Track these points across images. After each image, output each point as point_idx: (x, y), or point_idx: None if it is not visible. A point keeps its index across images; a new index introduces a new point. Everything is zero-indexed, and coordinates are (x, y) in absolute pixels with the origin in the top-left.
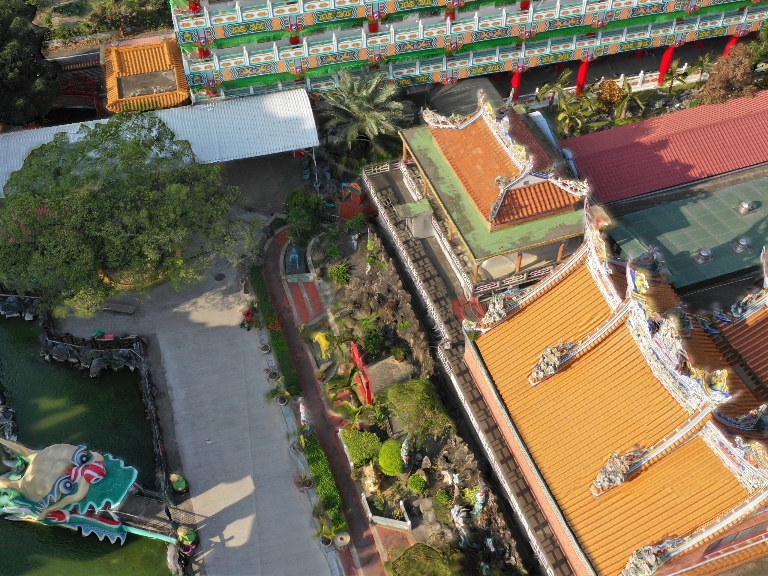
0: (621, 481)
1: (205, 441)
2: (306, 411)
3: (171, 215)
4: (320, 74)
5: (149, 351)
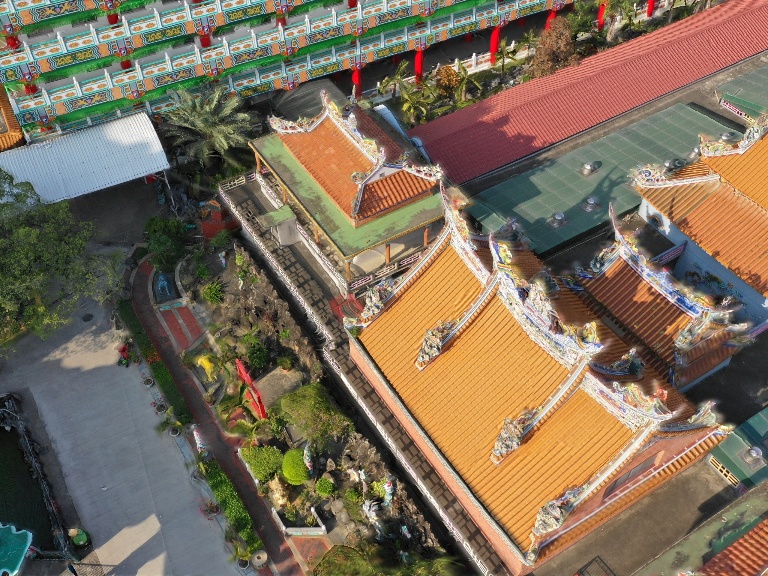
0: (517, 445)
1: (100, 488)
2: (201, 437)
3: (24, 262)
4: (159, 96)
5: (24, 407)
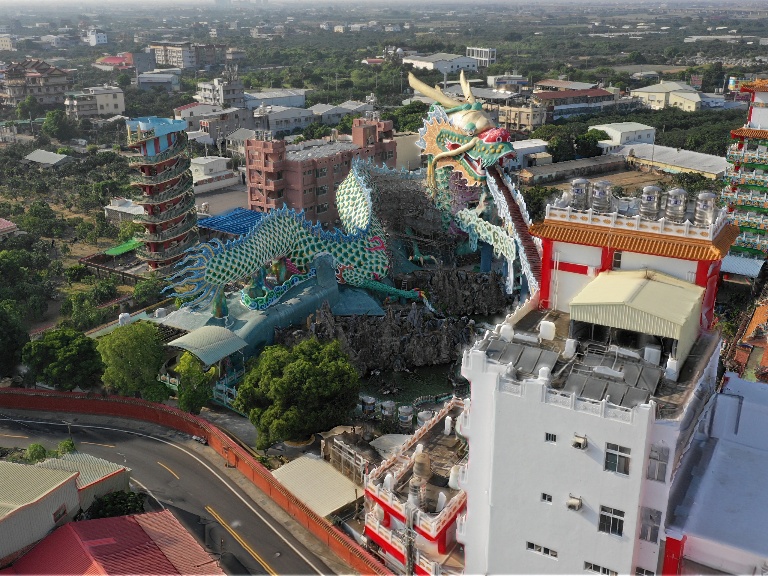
0: (767, 325)
1: None
2: None
3: None
4: None
5: None
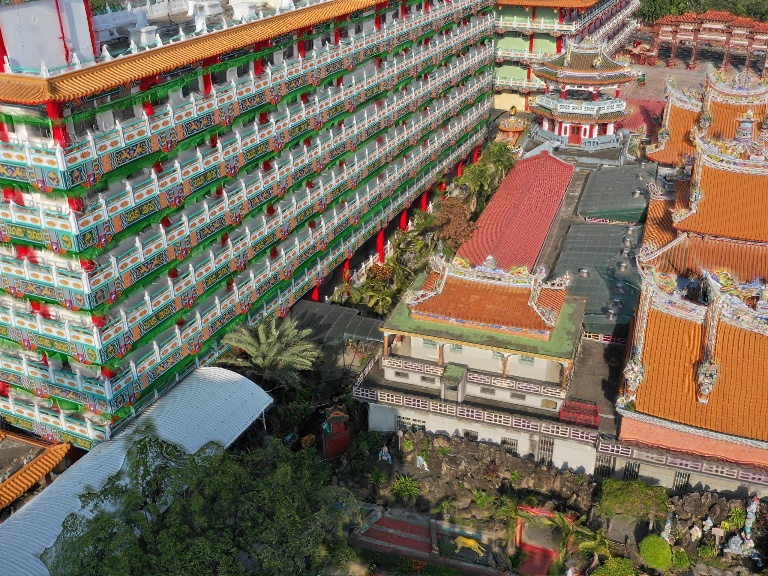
0: None
1: None
2: None
3: (297, 504)
4: (204, 348)
5: None
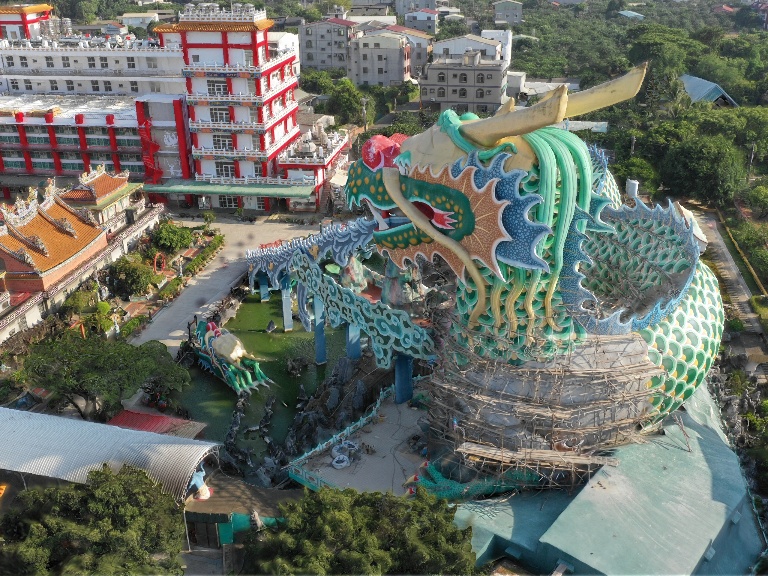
0: None
1: None
2: None
3: None
4: None
5: None
